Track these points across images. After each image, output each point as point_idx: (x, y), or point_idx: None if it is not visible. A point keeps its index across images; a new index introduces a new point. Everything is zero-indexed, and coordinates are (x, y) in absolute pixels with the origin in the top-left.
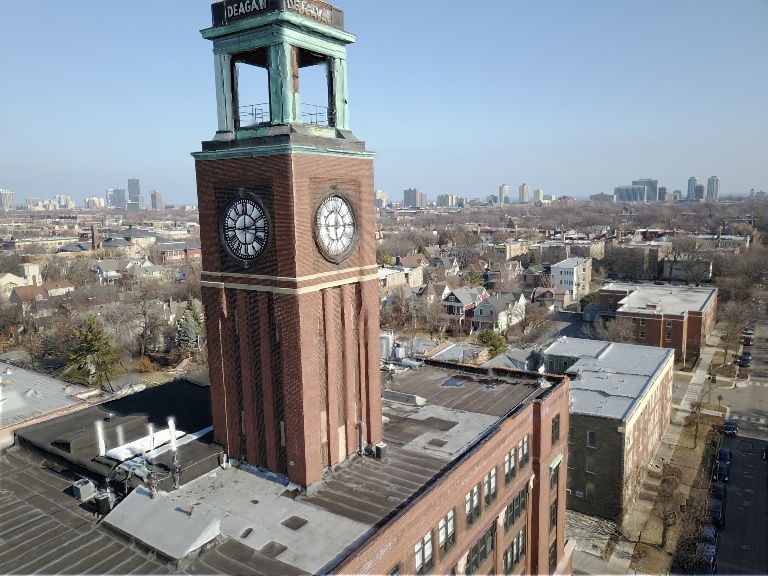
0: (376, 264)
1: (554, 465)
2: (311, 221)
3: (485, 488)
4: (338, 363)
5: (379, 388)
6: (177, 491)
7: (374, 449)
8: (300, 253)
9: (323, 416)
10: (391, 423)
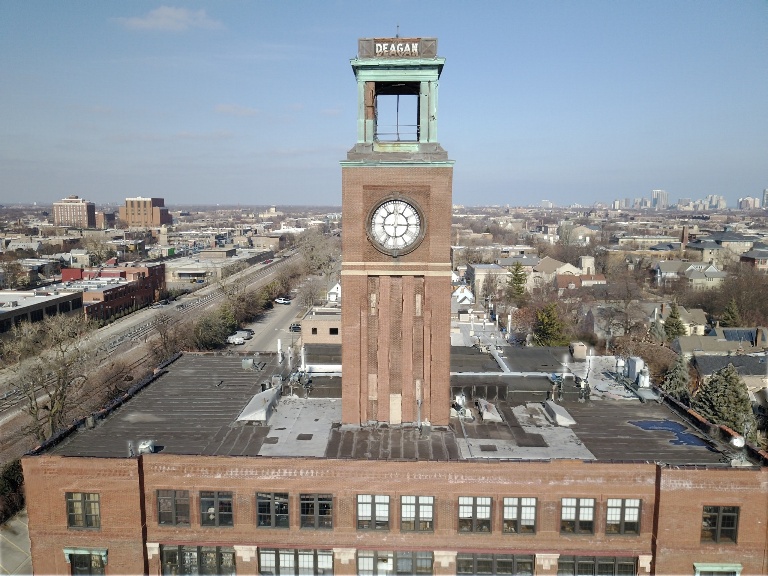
0: (450, 263)
1: (704, 567)
2: (365, 220)
3: (508, 510)
4: (395, 340)
5: (446, 376)
6: (304, 399)
7: (433, 428)
8: (347, 244)
9: (373, 378)
10: (497, 424)
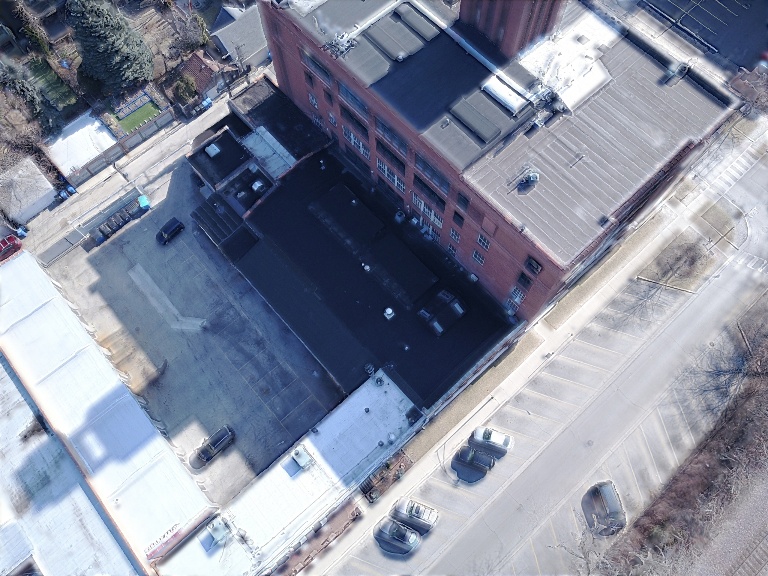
0: None
1: None
2: None
3: None
4: None
5: None
6: None
7: None
8: None
9: None
10: None
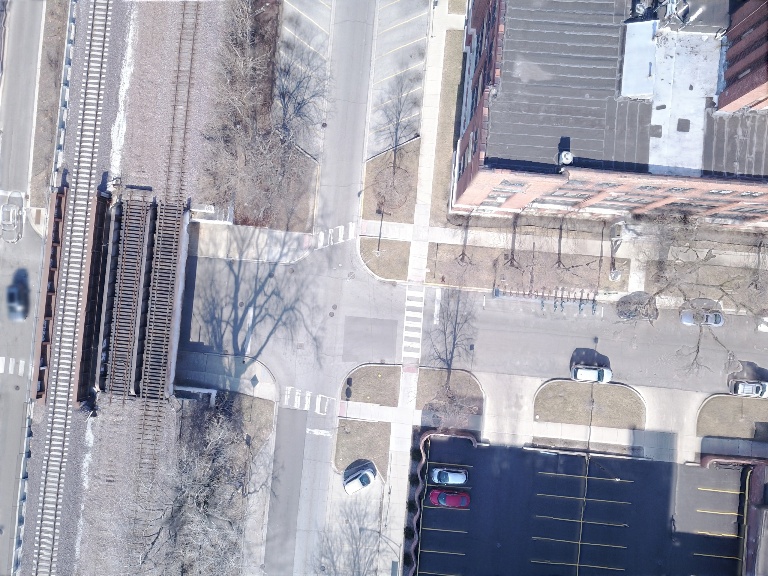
0: None
1: None
2: None
3: None
4: None
5: None
6: (676, 33)
7: None
8: None
9: None
10: None
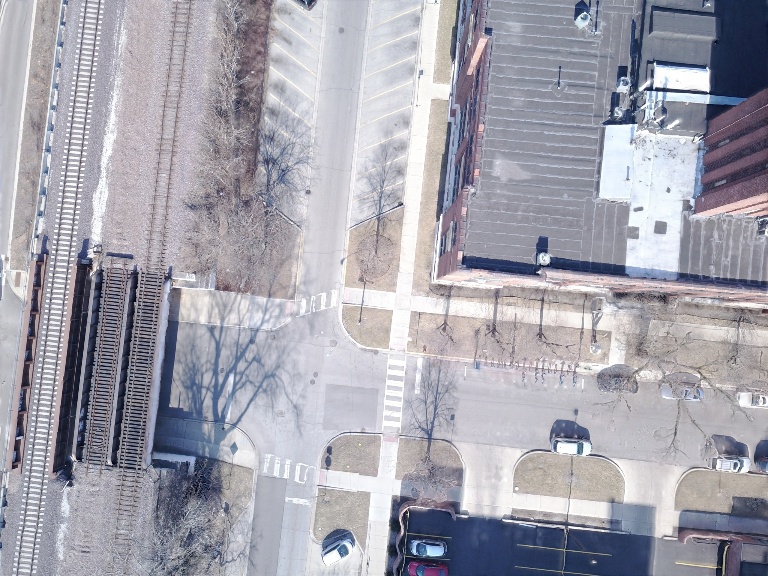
0: None
1: None
2: None
3: None
4: None
5: None
6: (654, 136)
7: None
8: None
9: None
10: None
